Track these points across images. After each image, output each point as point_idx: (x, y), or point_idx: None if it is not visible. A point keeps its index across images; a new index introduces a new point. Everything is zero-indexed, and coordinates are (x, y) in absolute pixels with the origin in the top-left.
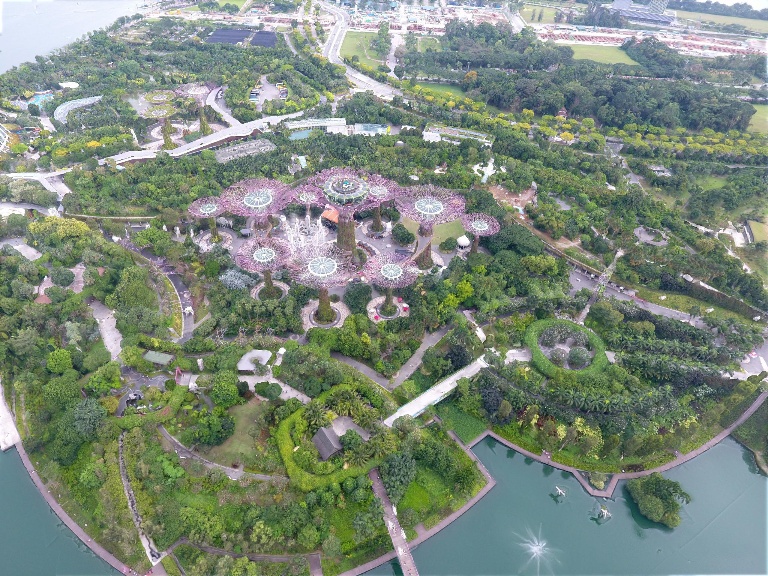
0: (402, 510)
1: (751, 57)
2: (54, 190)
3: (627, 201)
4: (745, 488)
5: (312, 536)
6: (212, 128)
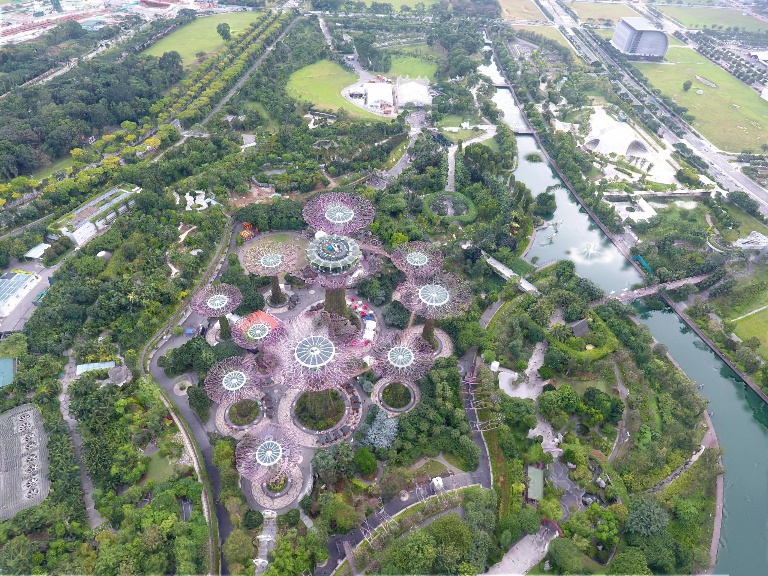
0: None
1: (64, 26)
2: None
3: (286, 140)
4: None
5: None
6: None
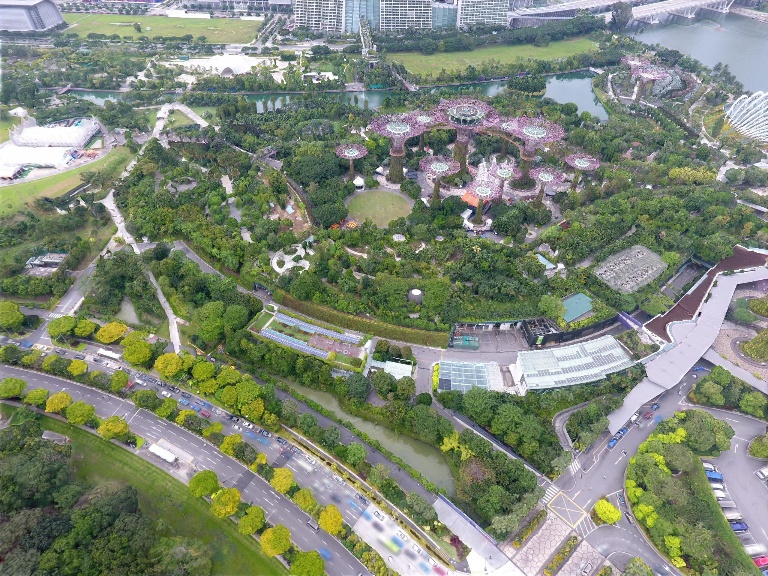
0: None
1: None
2: (765, 211)
3: None
4: None
5: None
6: (760, 368)
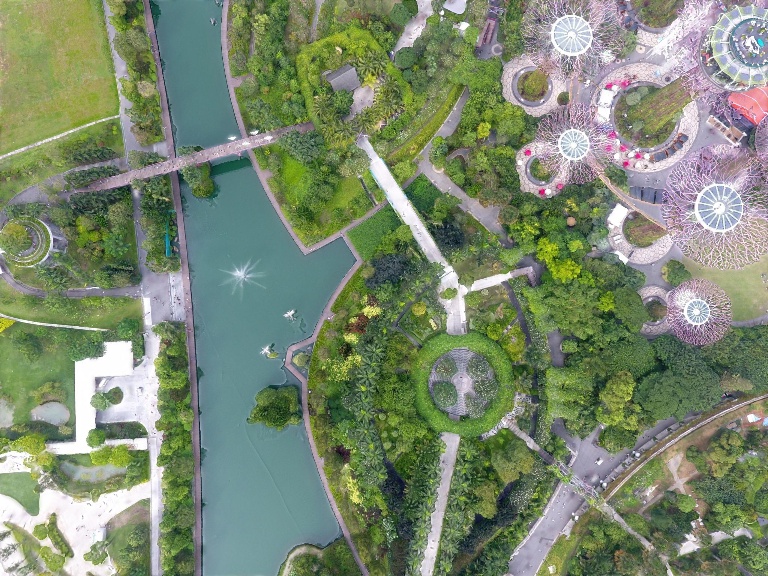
0: (280, 155)
1: None
2: None
3: None
4: (298, 523)
5: (252, 64)
6: None
